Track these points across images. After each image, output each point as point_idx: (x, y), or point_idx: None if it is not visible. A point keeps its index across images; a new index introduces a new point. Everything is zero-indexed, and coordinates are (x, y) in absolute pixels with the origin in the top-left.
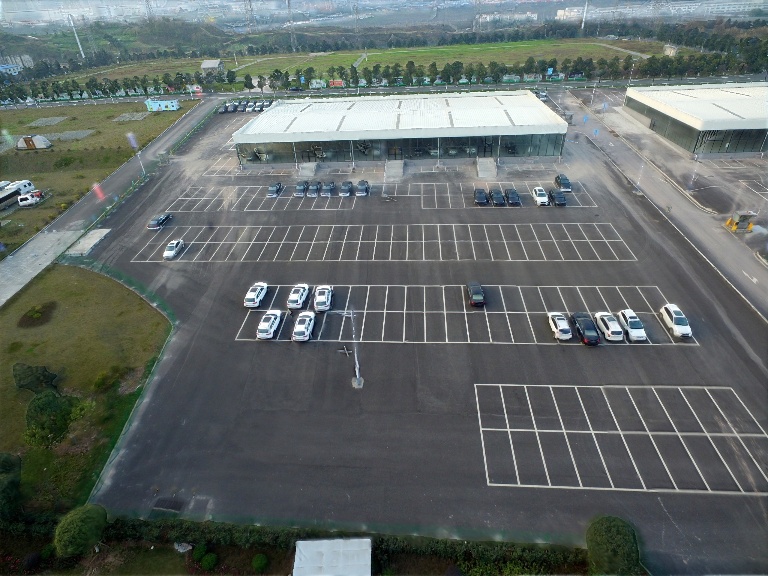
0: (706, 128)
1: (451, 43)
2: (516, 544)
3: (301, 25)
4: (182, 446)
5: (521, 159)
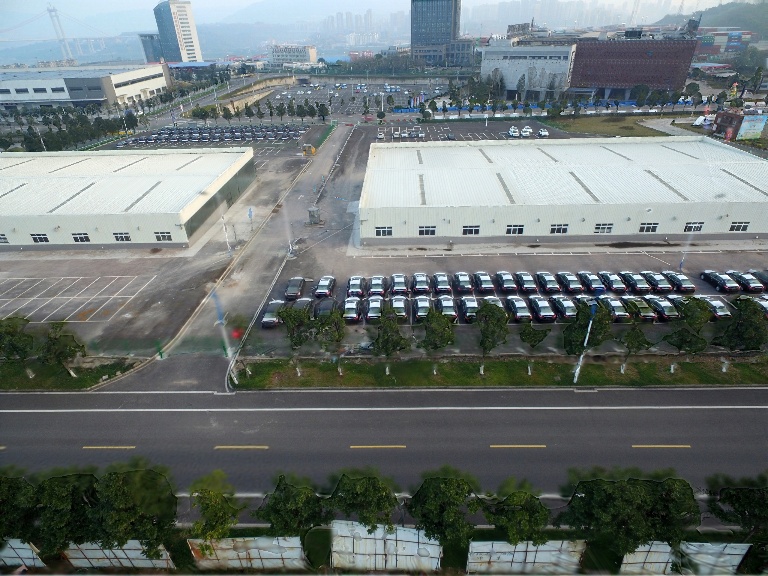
0: None
1: None
2: (443, 119)
3: None
4: (526, 124)
5: None
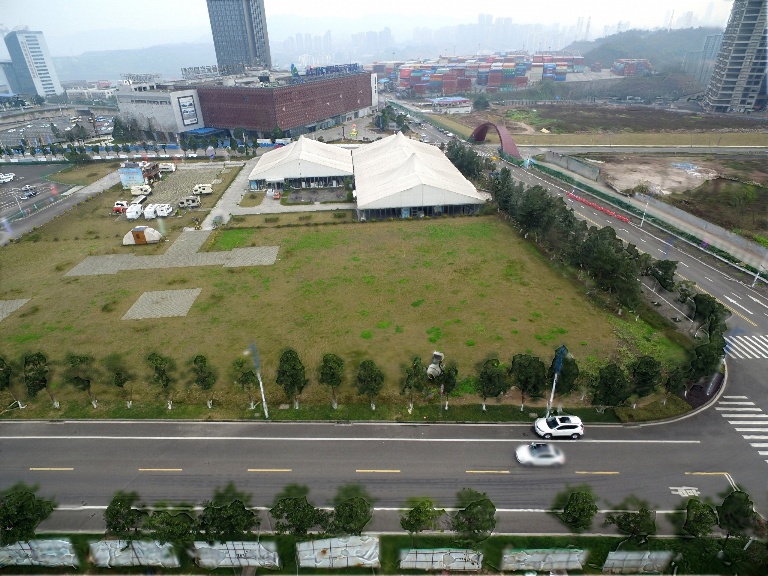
0: None
1: None
2: None
3: None
4: None
5: None
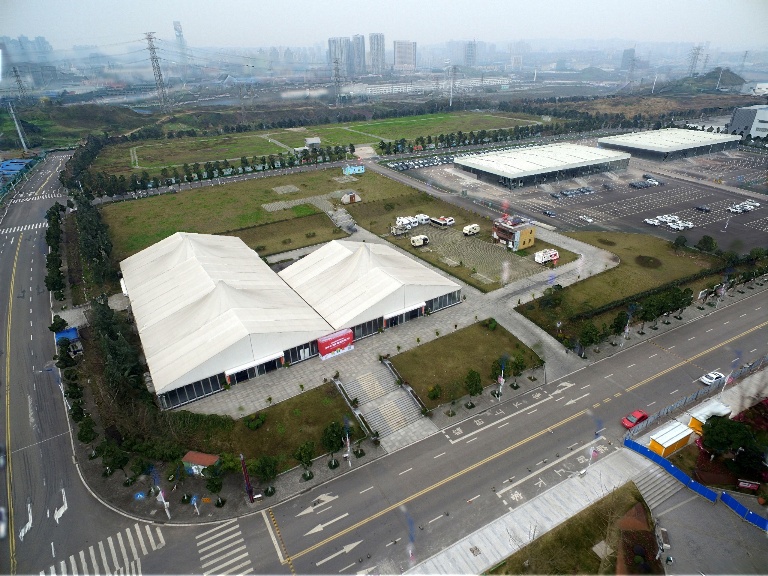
0: (667, 151)
1: (382, 117)
2: None
3: (188, 104)
4: None
5: (615, 172)
